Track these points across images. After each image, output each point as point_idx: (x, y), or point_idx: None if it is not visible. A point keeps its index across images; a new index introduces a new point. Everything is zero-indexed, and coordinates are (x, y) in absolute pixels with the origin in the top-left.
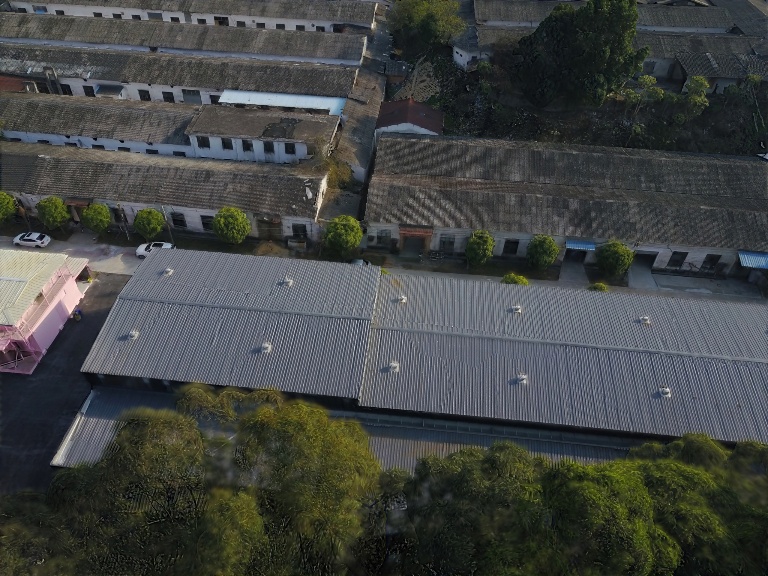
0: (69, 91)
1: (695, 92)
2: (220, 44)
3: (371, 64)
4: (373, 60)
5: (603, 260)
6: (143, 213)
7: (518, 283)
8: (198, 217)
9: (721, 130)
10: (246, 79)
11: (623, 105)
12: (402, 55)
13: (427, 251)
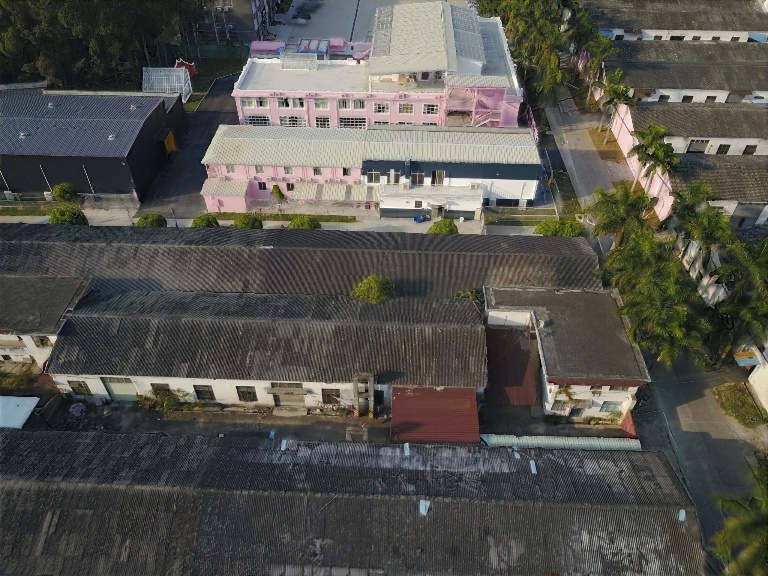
0: None
1: None
2: None
3: None
4: None
5: None
6: (151, 216)
7: None
8: None
9: None
10: None
11: None
12: None
13: None
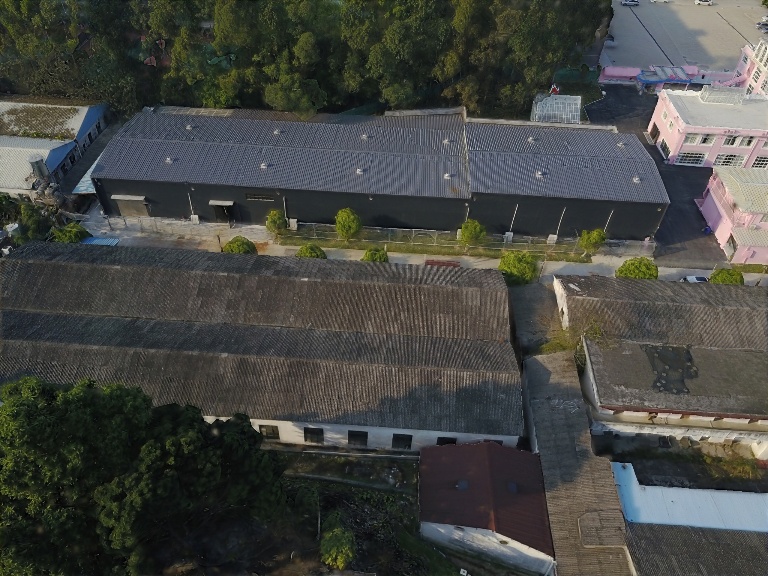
0: None
1: None
2: None
3: None
4: None
5: None
6: (736, 273)
7: (349, 208)
8: None
9: None
10: None
11: None
12: None
13: None
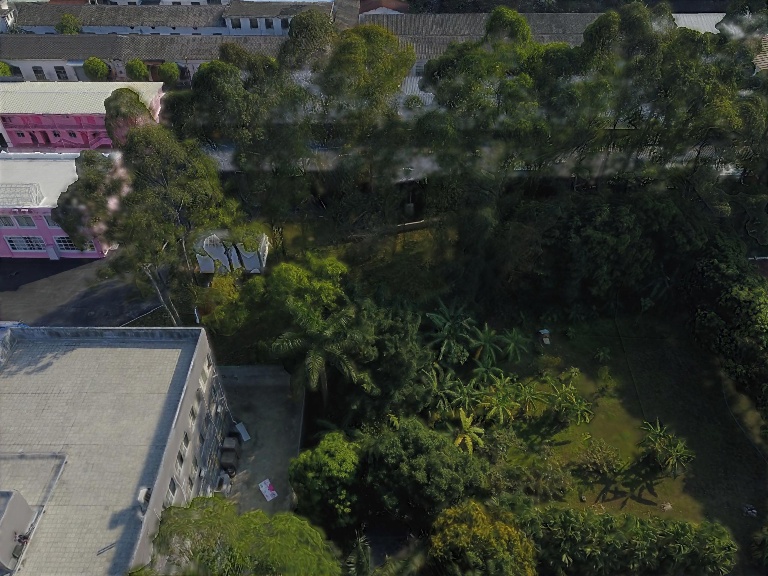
0: None
1: None
2: None
3: None
4: None
5: None
6: (204, 64)
7: None
8: None
9: (610, 1)
10: None
11: None
12: None
13: None
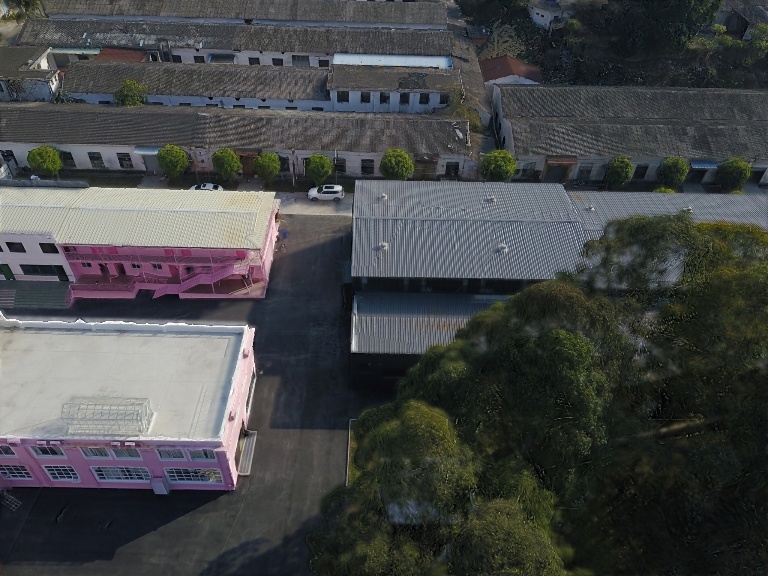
0: (179, 62)
1: (759, 38)
2: (313, 14)
3: (454, 29)
4: (454, 25)
5: (727, 175)
6: (315, 158)
7: None
8: (359, 161)
9: None
10: (353, 43)
11: (695, 53)
12: (474, 21)
13: (569, 179)
